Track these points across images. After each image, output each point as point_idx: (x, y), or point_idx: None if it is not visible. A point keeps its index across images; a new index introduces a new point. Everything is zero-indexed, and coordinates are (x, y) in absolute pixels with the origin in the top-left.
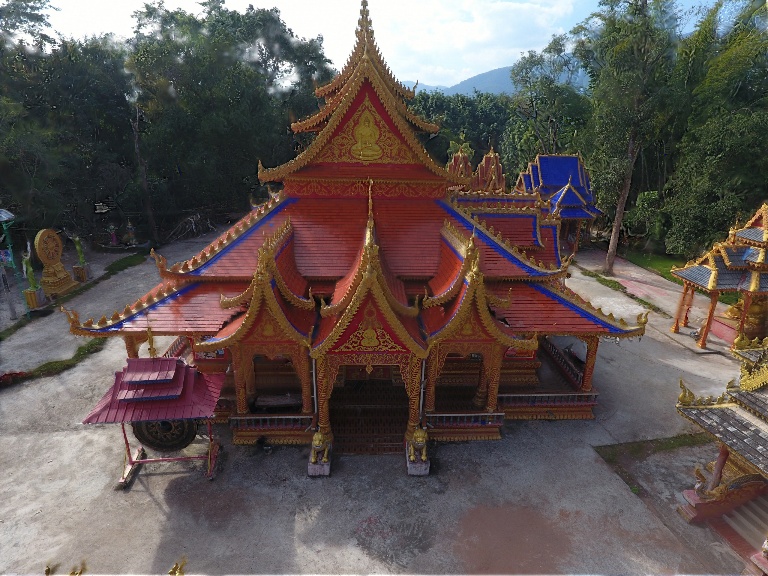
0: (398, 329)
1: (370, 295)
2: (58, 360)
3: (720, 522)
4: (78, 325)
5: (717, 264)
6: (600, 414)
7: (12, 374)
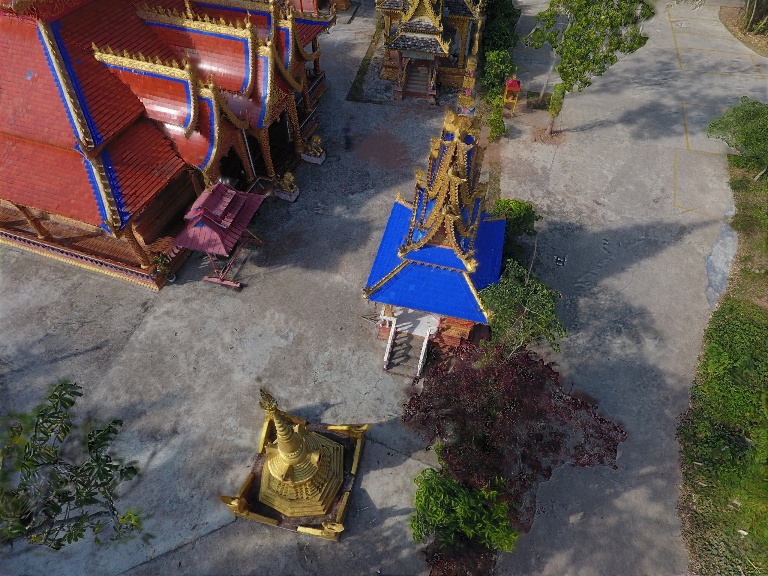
0: None
1: (275, 63)
2: None
3: (407, 92)
4: None
5: None
6: (326, 85)
7: None
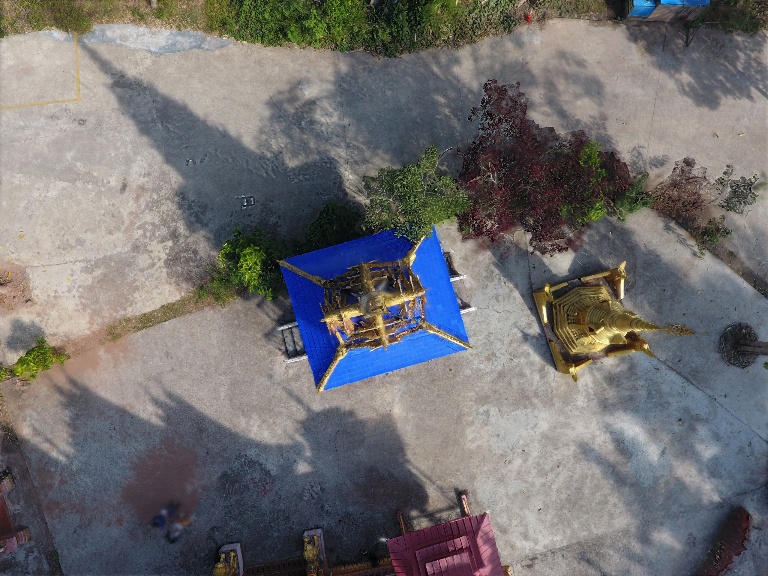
0: None
1: None
2: None
3: (3, 531)
4: None
5: None
6: None
7: None
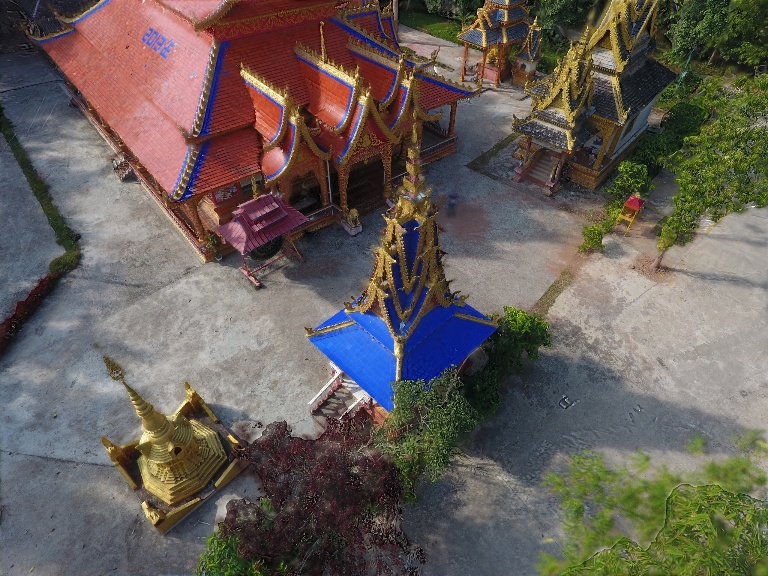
0: (385, 130)
1: (370, 113)
2: (56, 257)
3: (528, 177)
4: (169, 201)
5: (485, 27)
6: (457, 148)
7: (45, 279)
